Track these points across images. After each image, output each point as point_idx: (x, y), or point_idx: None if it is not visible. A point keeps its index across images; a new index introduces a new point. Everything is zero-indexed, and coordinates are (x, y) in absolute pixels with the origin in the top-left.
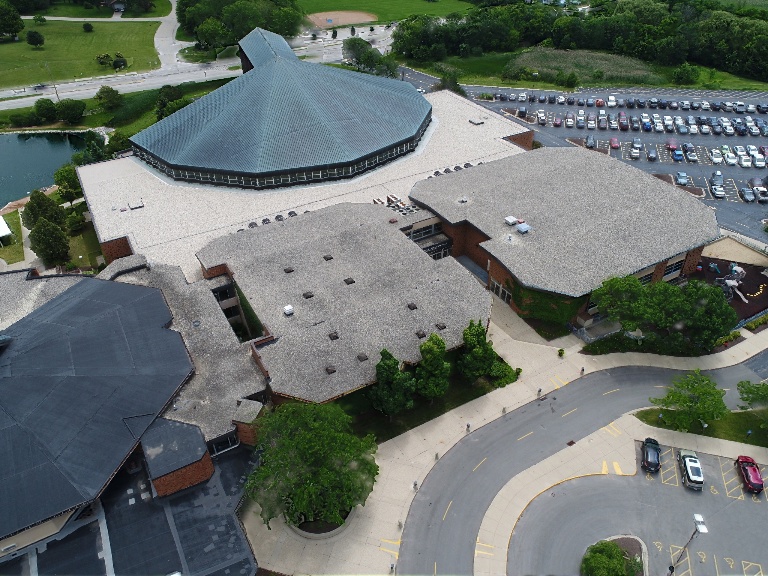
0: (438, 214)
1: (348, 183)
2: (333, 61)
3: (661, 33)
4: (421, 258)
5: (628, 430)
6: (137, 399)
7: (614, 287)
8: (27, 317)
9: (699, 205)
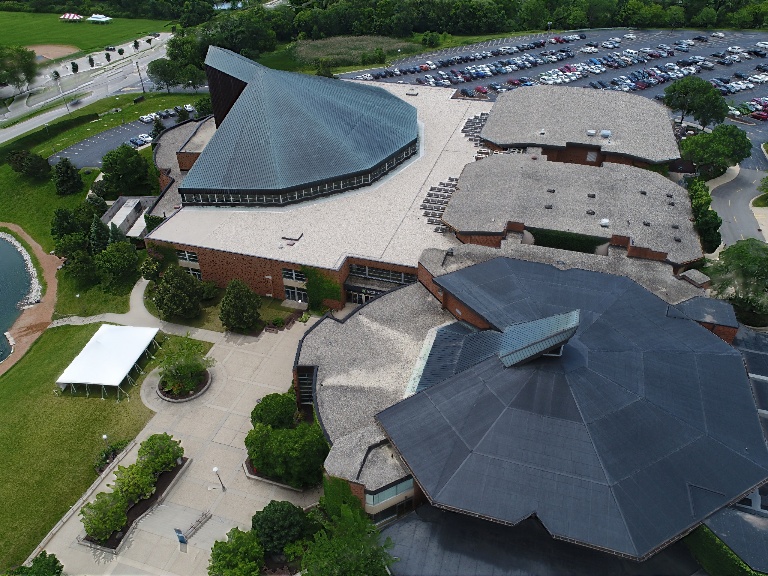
0: (545, 145)
1: (421, 157)
2: (114, 93)
3: (383, 13)
4: (594, 169)
5: (764, 213)
6: (649, 304)
7: (699, 142)
8: (482, 313)
9: (637, 96)
